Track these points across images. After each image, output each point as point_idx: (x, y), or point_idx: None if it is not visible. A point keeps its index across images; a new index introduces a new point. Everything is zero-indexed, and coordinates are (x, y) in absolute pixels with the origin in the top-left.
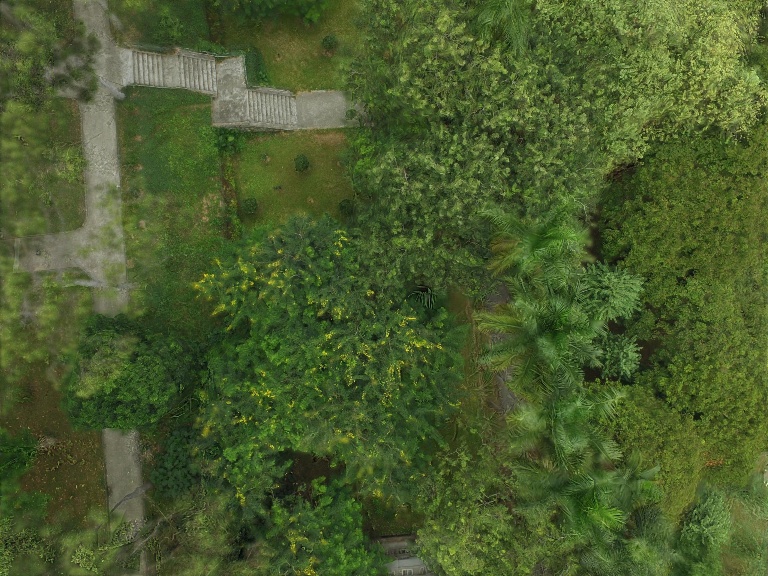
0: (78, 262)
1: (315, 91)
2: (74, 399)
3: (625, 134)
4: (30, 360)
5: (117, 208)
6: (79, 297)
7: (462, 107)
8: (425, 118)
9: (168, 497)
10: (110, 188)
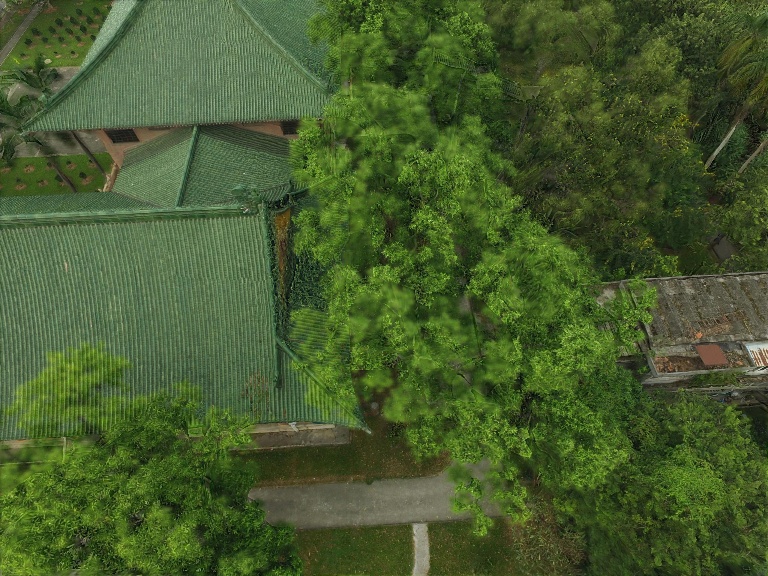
0: (406, 131)
1: (532, 86)
2: (464, 130)
3: (767, 46)
4: (372, 178)
5: (431, 109)
6: (408, 146)
7: (685, 3)
8: (661, 15)
9: (489, 251)
10: (426, 101)
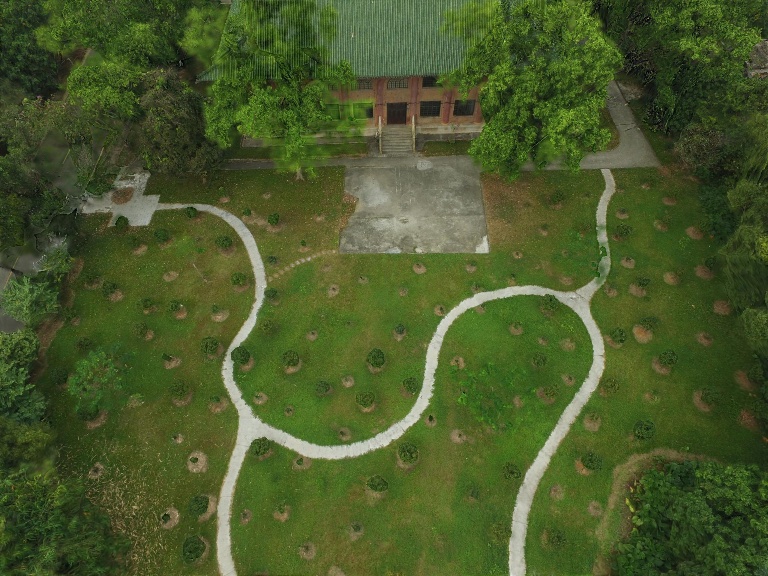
0: None
1: None
2: None
3: None
4: None
5: None
6: None
7: None
8: None
9: None
10: None
